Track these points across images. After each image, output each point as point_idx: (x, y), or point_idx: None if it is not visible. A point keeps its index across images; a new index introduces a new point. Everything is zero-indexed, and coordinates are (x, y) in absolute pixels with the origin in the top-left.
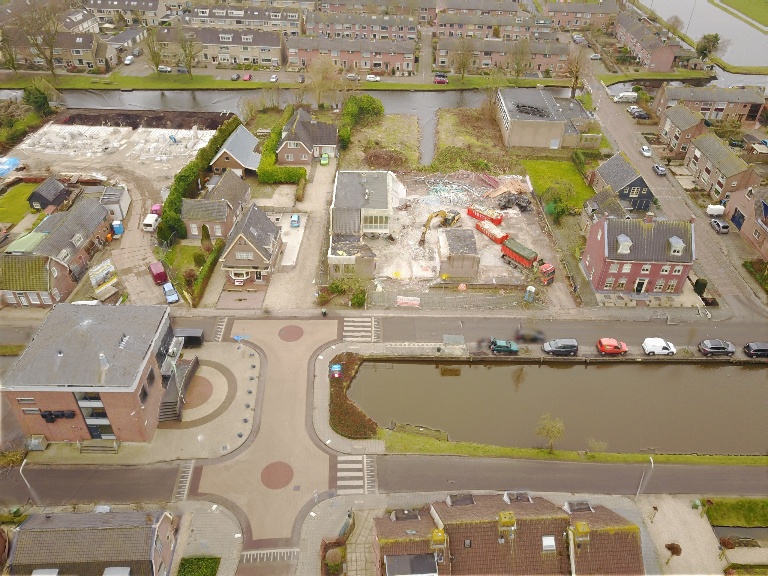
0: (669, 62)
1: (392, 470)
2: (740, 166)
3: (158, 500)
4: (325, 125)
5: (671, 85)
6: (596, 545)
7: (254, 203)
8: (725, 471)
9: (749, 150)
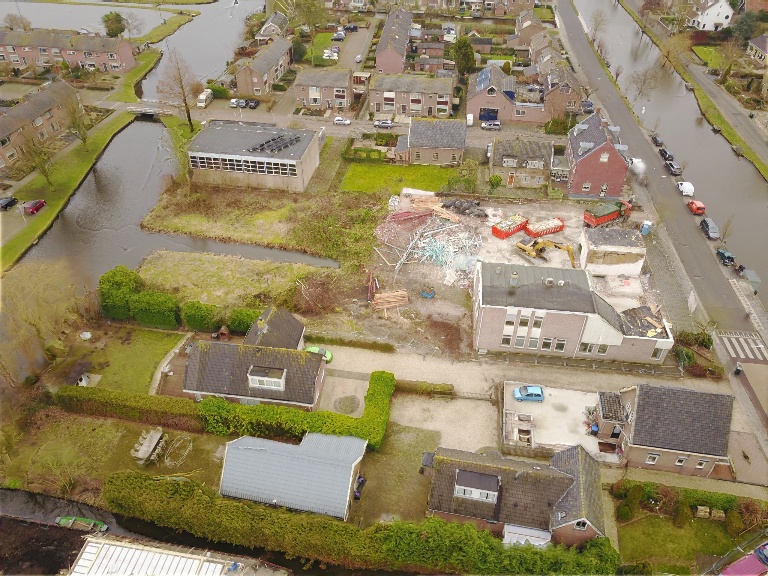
0: (131, 54)
1: None
2: (444, 82)
3: None
4: (275, 318)
5: (248, 62)
6: None
7: (641, 385)
8: None
9: (354, 80)
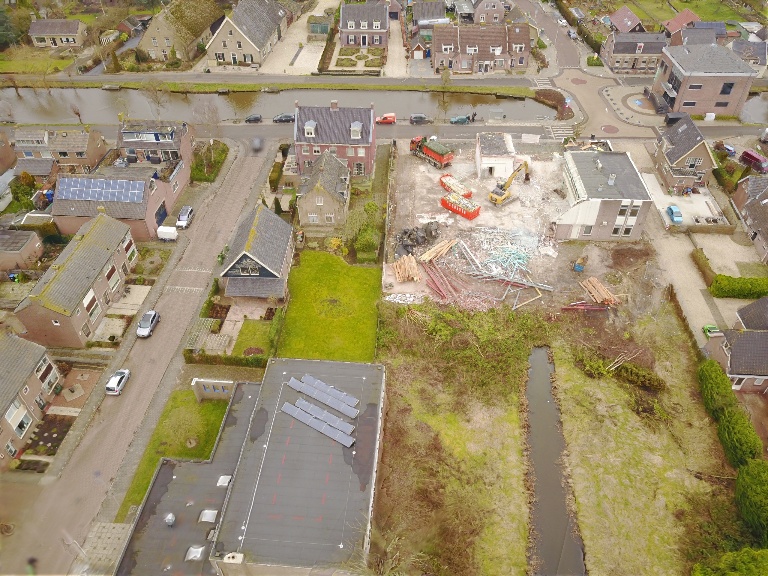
0: None
1: (524, 83)
2: (104, 223)
3: (629, 78)
4: None
5: None
6: None
7: None
8: None
9: None
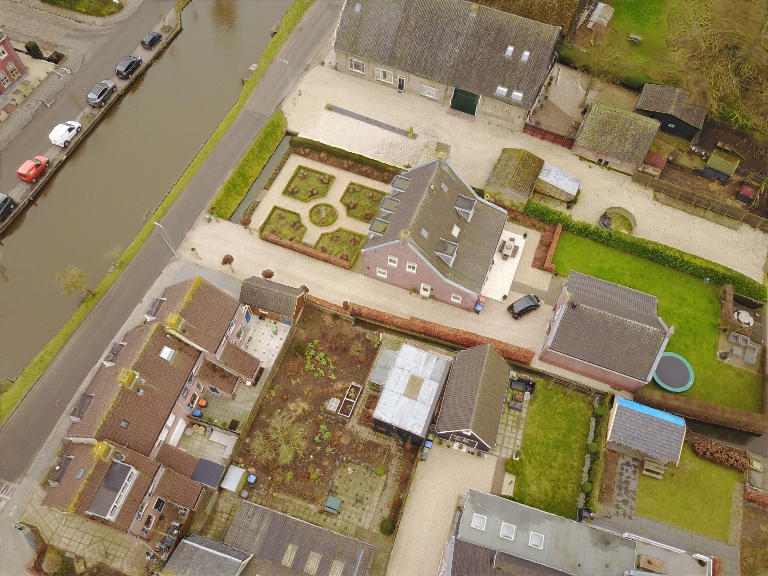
0: None
1: (3, 458)
2: None
3: None
4: None
5: None
6: (191, 317)
7: None
8: (199, 178)
9: None
